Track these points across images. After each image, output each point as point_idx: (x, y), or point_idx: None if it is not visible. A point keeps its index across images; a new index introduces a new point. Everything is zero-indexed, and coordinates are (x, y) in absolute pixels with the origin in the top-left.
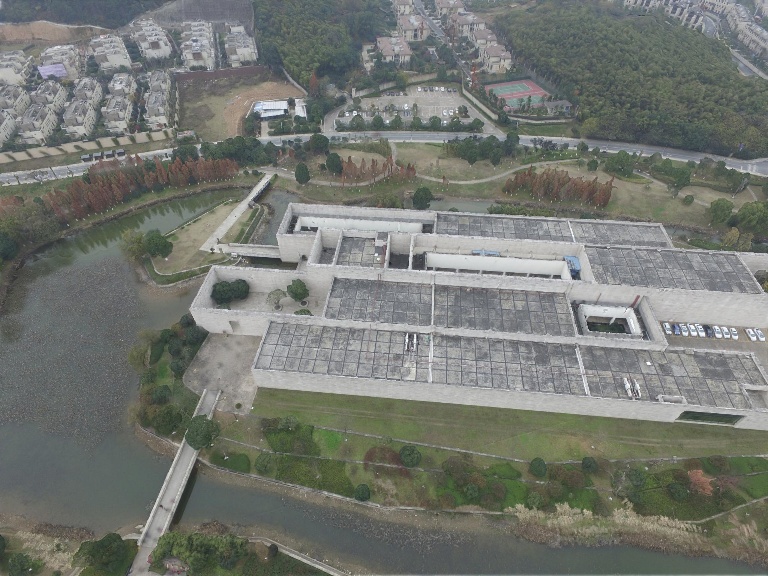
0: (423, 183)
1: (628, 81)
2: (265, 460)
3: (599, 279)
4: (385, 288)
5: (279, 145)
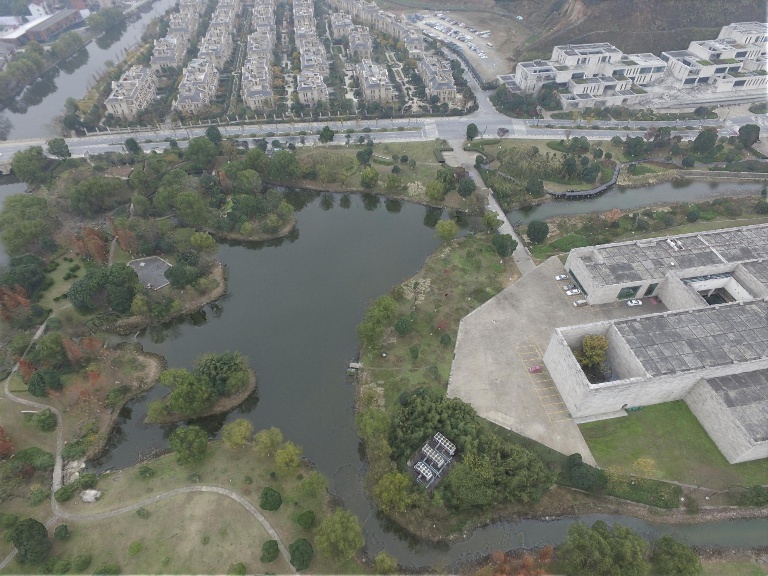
0: None
1: None
2: None
3: (767, 307)
4: None
5: None
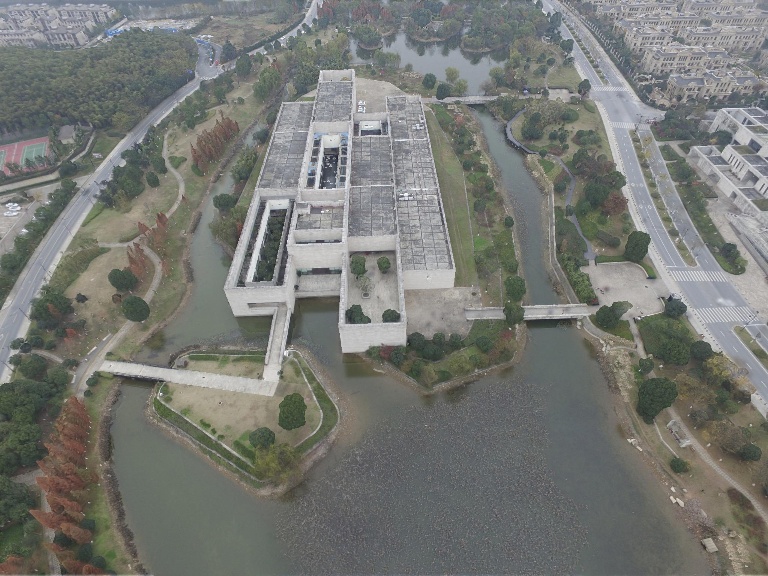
0: (172, 222)
1: (73, 84)
2: (513, 260)
3: None
4: (357, 210)
5: (5, 377)
